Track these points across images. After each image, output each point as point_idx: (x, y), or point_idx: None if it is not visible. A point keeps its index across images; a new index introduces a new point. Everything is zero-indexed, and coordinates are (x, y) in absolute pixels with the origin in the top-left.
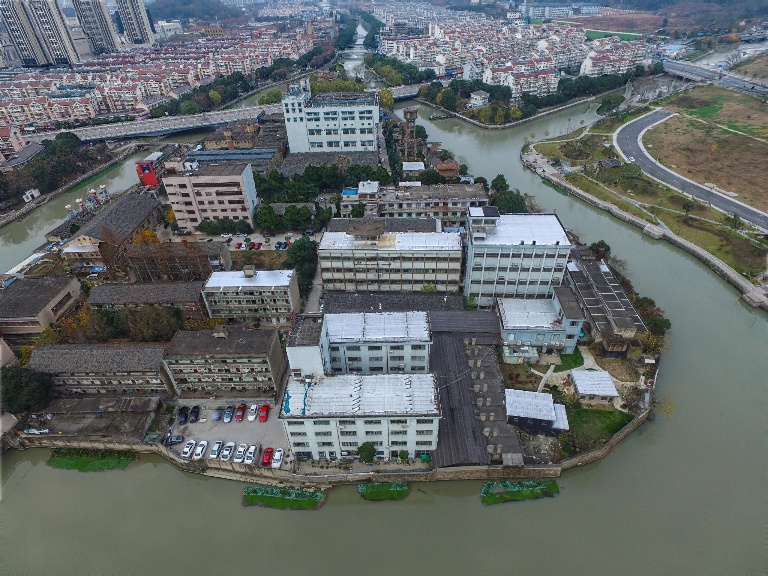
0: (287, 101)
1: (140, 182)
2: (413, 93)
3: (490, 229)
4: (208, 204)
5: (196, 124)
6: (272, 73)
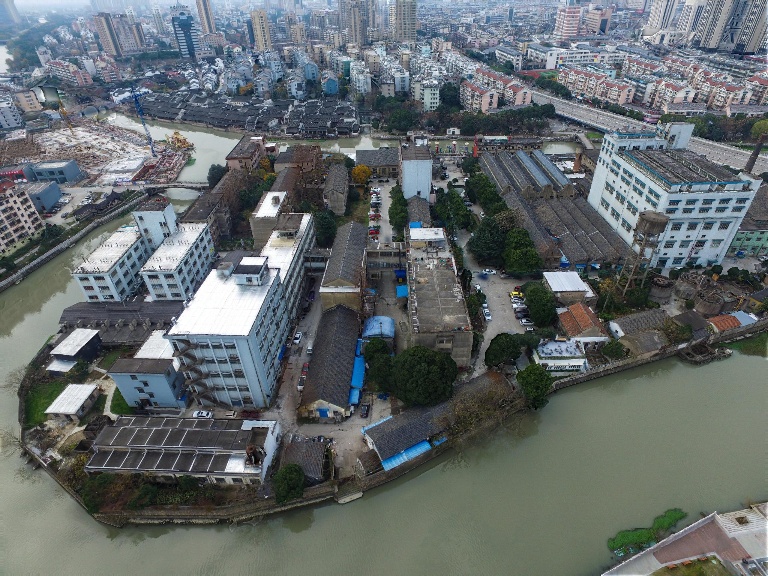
0: (608, 137)
1: None
2: None
3: (235, 280)
4: None
5: None
6: None
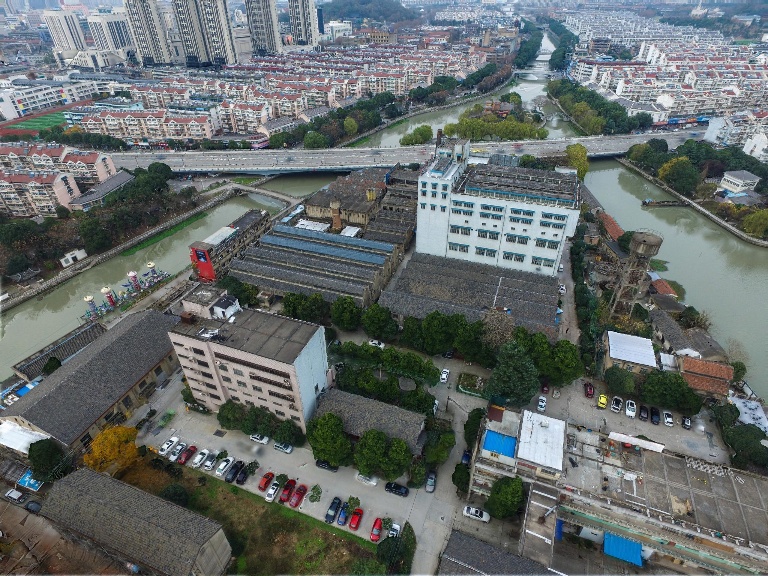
0: (426, 179)
1: (194, 270)
2: (617, 151)
3: None
4: (237, 384)
5: (313, 166)
6: (428, 96)
